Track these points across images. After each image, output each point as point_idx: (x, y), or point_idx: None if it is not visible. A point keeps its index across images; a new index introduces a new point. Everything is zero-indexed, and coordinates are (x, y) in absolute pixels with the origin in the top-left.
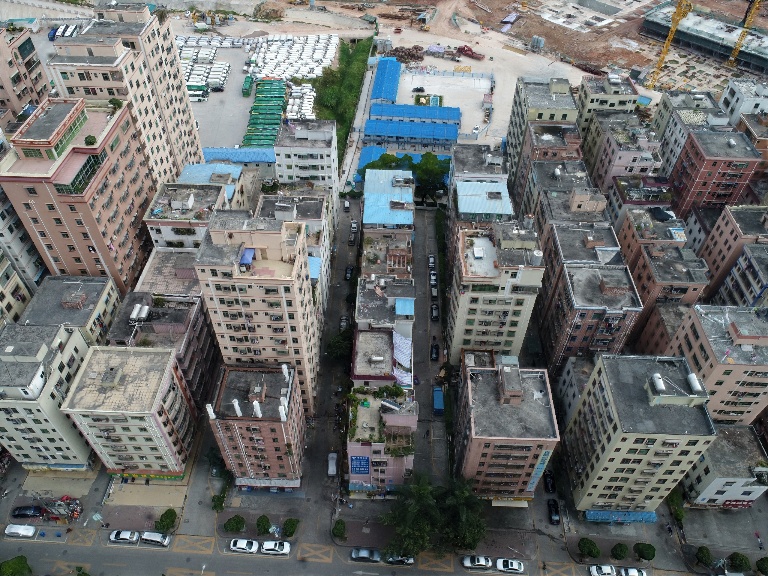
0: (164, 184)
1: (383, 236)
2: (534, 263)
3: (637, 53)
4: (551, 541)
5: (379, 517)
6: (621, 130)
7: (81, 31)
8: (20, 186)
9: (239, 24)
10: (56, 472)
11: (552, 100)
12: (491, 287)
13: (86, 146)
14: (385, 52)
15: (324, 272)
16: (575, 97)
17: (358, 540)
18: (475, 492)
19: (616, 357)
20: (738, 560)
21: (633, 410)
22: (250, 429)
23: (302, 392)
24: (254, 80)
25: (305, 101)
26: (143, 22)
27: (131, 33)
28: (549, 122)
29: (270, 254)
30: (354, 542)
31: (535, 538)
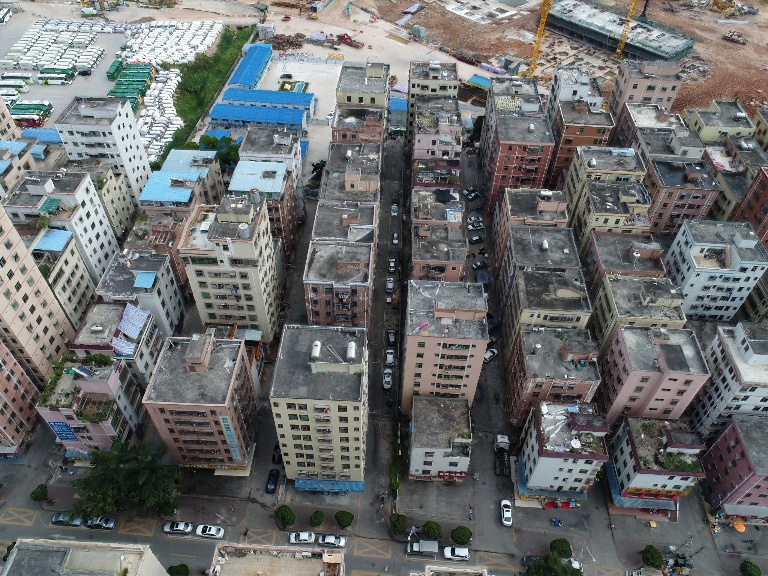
0: None
1: (163, 214)
2: (242, 236)
3: (530, 44)
4: (261, 509)
5: (70, 481)
6: (429, 114)
7: None
8: None
9: (129, 10)
10: None
11: (364, 84)
12: (210, 260)
13: None
14: (266, 39)
15: (92, 247)
16: None
17: (65, 505)
18: (187, 460)
19: (300, 327)
20: (427, 528)
21: (293, 377)
22: None
23: (28, 361)
24: (124, 64)
25: (167, 85)
26: None
27: None
28: (357, 105)
29: None
30: (61, 507)
31: (246, 506)
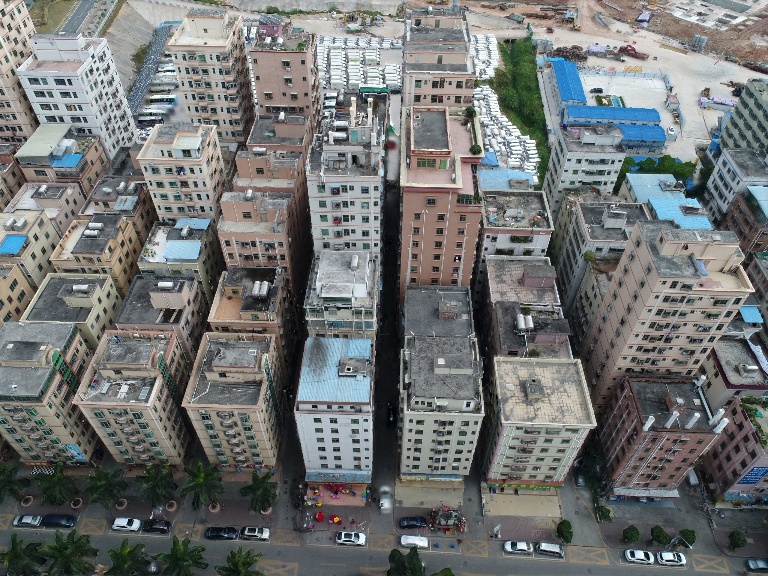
0: (483, 191)
1: None
2: None
3: None
4: None
5: None
6: None
7: (406, 38)
8: (422, 196)
9: (388, 25)
10: (422, 482)
11: None
12: None
13: (473, 155)
14: (545, 52)
15: None
16: None
17: (746, 551)
18: None
19: None
20: None
21: None
22: (677, 441)
23: None
24: None
25: (491, 103)
26: (459, 28)
27: (456, 39)
28: None
29: (711, 265)
30: (743, 553)
31: None
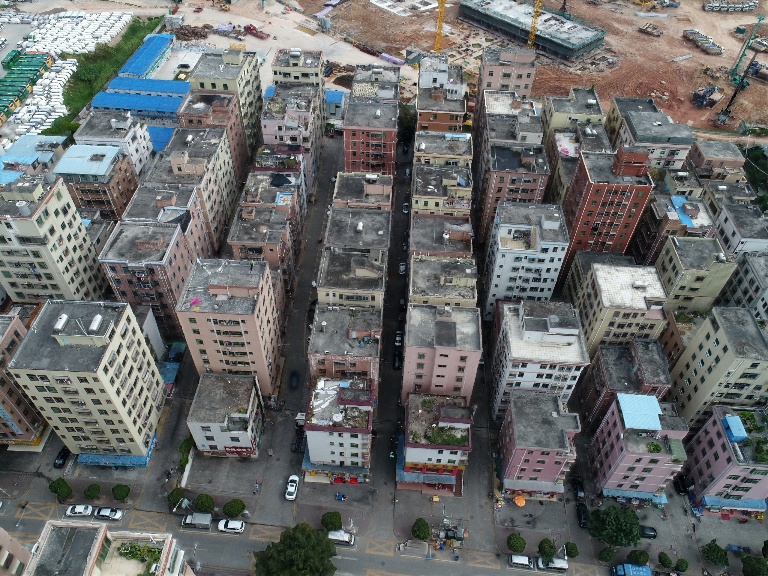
0: None
1: None
2: (21, 214)
3: (445, 36)
4: (46, 483)
5: None
6: (281, 100)
7: None
8: None
9: (42, 1)
10: None
11: (219, 70)
12: None
13: None
14: None
15: None
16: (338, 75)
17: None
18: None
19: (64, 302)
20: (196, 500)
21: (40, 349)
22: None
23: None
24: None
25: (59, 75)
26: None
27: None
28: (209, 91)
29: None
30: None
31: (31, 480)
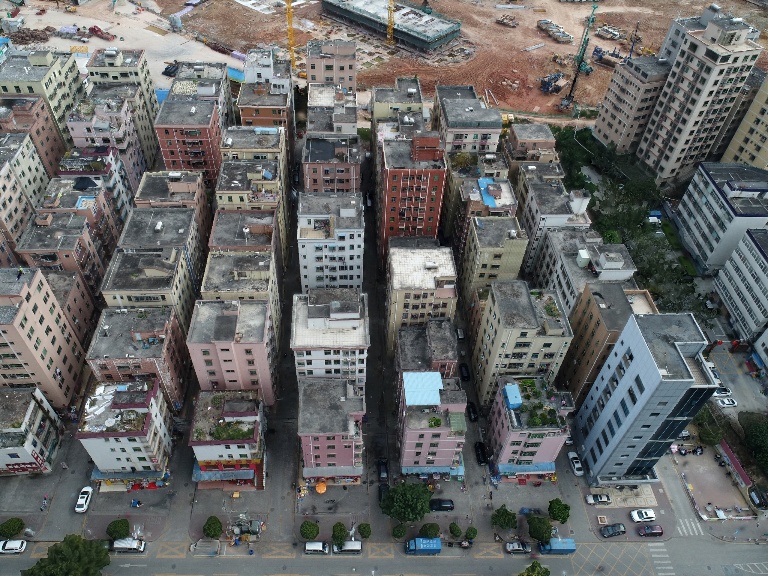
0: None
1: None
2: None
3: (308, 33)
4: None
5: None
6: (93, 101)
7: None
8: None
9: None
10: None
11: (24, 73)
12: None
13: None
14: None
15: None
16: None
17: None
18: None
19: None
20: None
21: None
22: None
23: None
24: None
25: None
26: None
27: None
28: (12, 95)
29: None
30: None
31: None
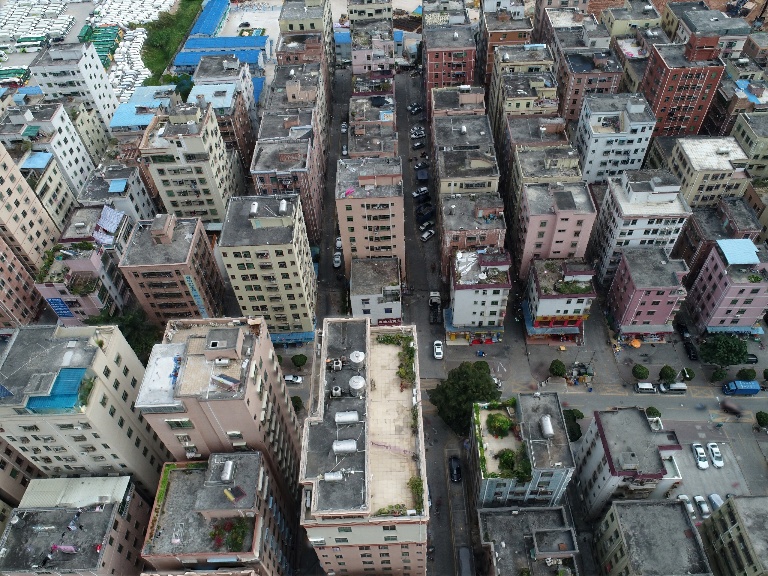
0: None
1: None
2: (191, 132)
3: None
4: None
5: None
6: (364, 34)
7: None
8: None
9: None
10: None
11: (304, 12)
12: (168, 158)
13: None
14: None
15: (73, 170)
16: None
17: None
18: None
19: (244, 198)
20: None
21: (238, 233)
22: None
23: (25, 259)
24: None
25: (134, 42)
26: None
27: None
28: (298, 32)
29: None
30: None
31: None
